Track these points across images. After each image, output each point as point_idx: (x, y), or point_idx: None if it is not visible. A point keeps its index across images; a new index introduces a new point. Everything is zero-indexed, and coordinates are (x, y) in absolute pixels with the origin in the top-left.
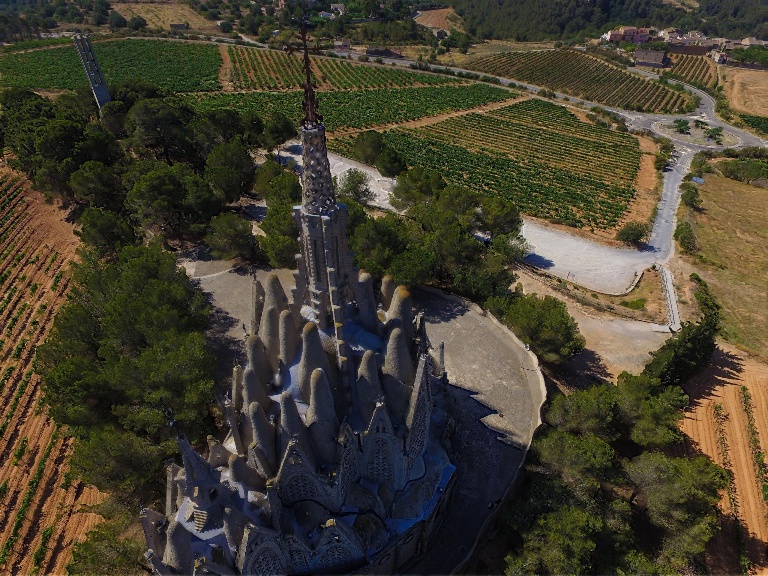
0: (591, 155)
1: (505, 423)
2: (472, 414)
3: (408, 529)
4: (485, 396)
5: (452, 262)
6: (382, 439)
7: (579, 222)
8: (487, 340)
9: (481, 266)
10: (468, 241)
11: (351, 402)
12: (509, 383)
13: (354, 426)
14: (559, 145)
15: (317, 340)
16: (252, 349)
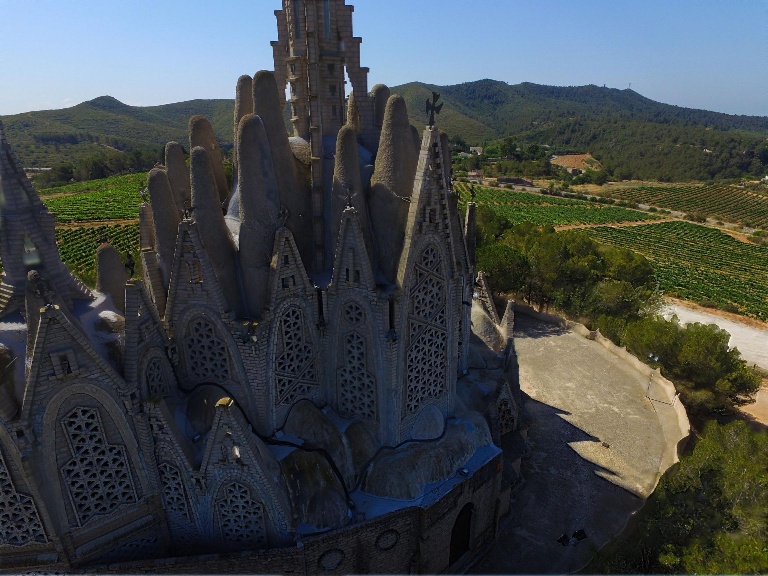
0: (756, 268)
1: (611, 456)
2: (555, 434)
3: (386, 513)
4: (581, 418)
5: (553, 286)
6: (355, 303)
7: (743, 314)
8: (593, 361)
9: (592, 289)
10: (577, 263)
11: (322, 246)
12: (623, 410)
13: (317, 280)
14: (712, 257)
15: (272, 101)
16: (192, 128)
